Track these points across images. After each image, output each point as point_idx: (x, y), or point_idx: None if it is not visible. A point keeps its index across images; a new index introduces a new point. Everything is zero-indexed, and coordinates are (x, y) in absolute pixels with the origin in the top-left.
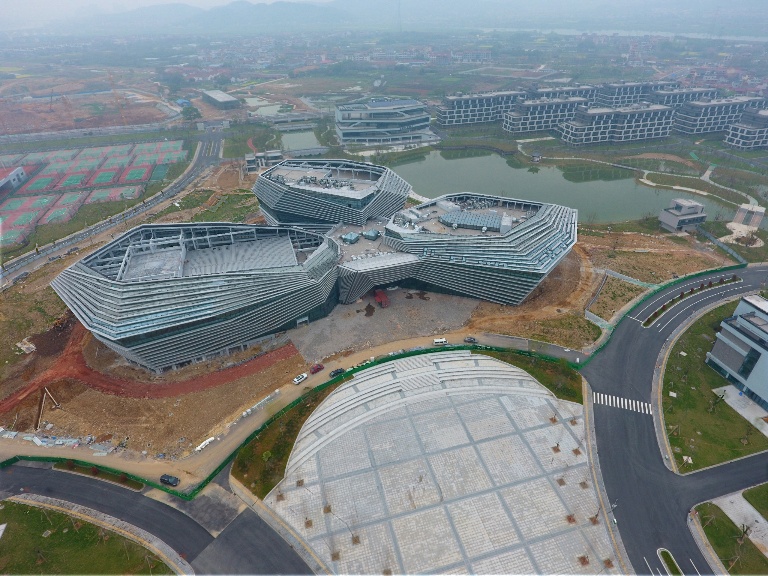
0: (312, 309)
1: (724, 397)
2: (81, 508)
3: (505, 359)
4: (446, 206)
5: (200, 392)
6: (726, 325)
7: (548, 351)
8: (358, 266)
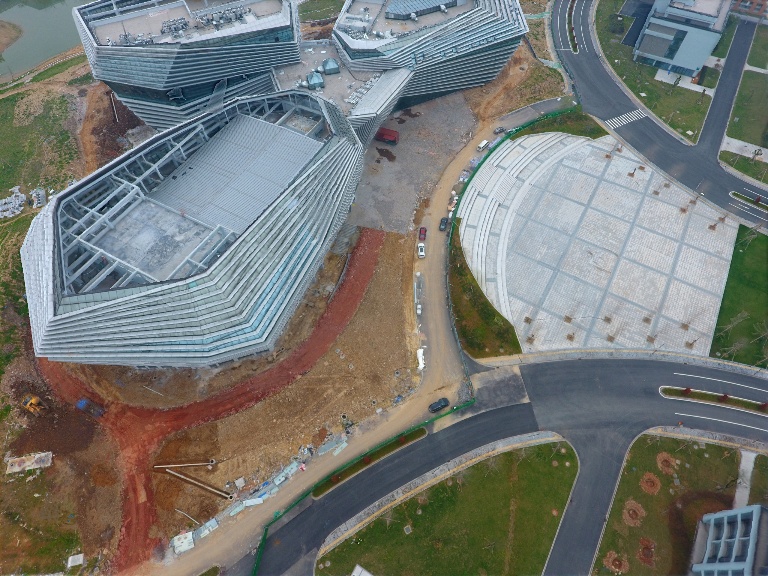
0: None
1: (664, 80)
2: (402, 490)
3: (537, 131)
4: None
5: (347, 329)
6: (655, 20)
7: (550, 107)
8: (372, 107)
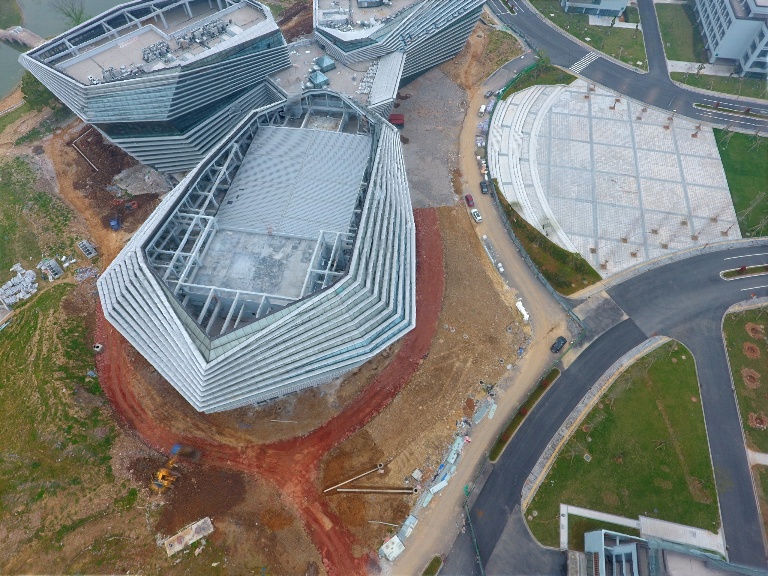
0: None
1: (598, 24)
2: (565, 426)
3: (520, 88)
4: None
5: (445, 304)
6: None
7: (519, 65)
8: (388, 93)
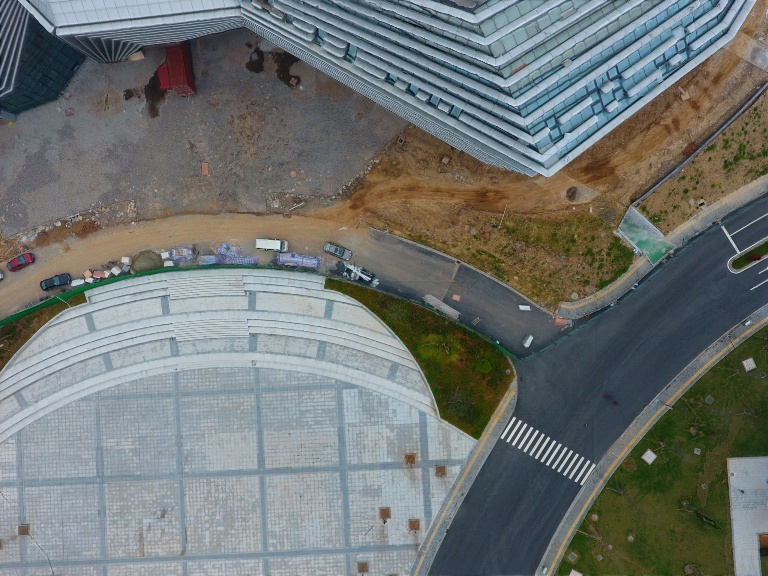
0: None
1: (736, 480)
2: None
3: (385, 315)
4: None
5: None
6: None
7: (485, 304)
8: (52, 10)
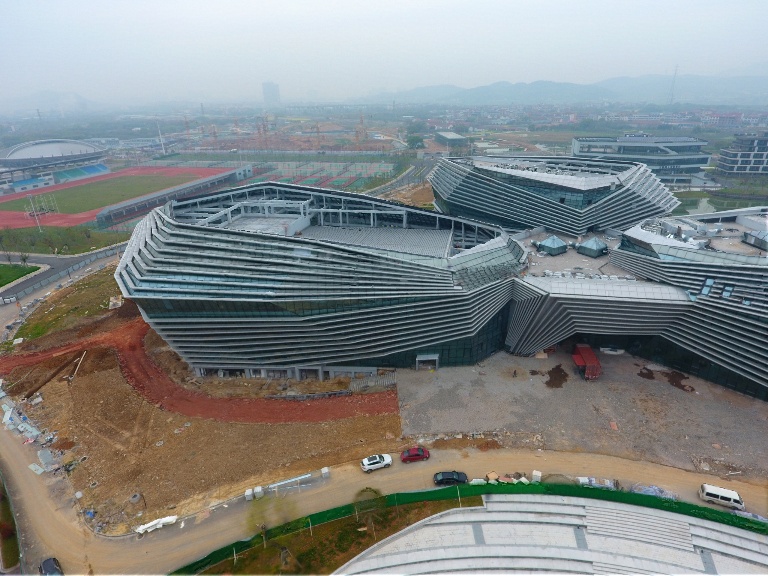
0: (448, 343)
1: None
2: None
3: None
4: (761, 223)
5: (220, 423)
6: None
7: None
8: (552, 285)
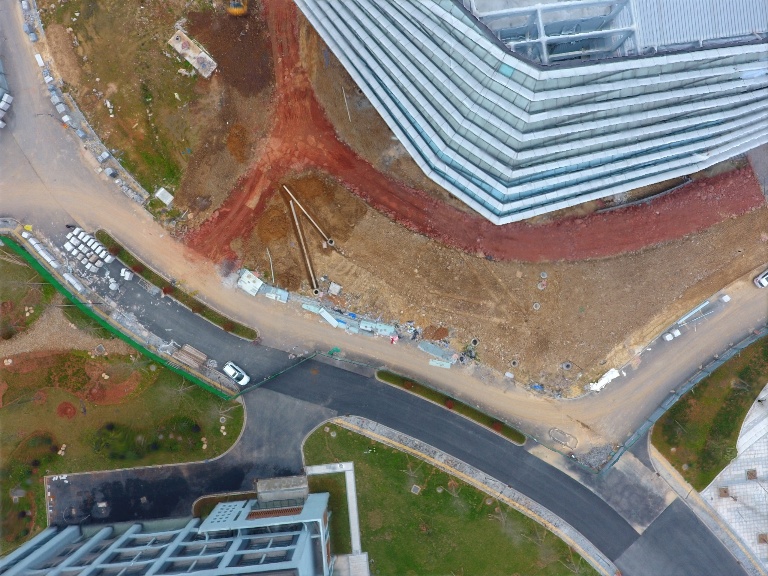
0: None
1: None
2: (447, 458)
3: None
4: None
5: (580, 265)
6: None
7: None
8: None
